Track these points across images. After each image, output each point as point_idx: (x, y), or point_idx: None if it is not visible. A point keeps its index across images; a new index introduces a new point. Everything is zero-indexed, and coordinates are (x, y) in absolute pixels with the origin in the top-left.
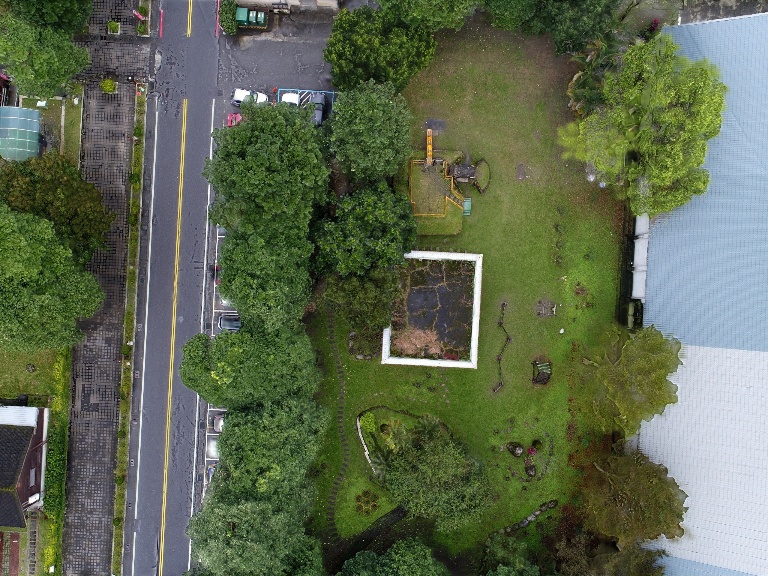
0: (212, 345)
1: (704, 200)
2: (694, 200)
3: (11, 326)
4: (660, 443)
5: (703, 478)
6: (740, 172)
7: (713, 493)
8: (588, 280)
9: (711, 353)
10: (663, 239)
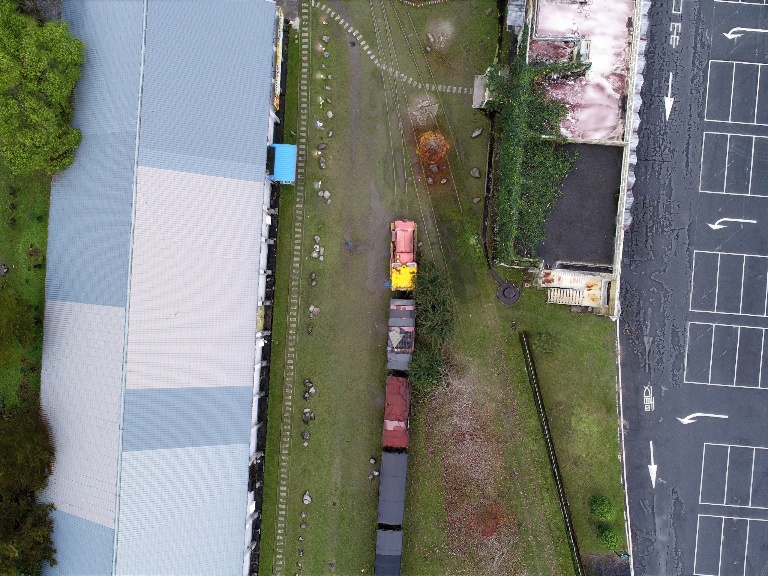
0: None
1: (84, 159)
2: (78, 159)
3: None
4: (53, 399)
5: (77, 432)
6: (105, 131)
7: (82, 447)
8: (41, 242)
9: (85, 309)
10: (59, 198)
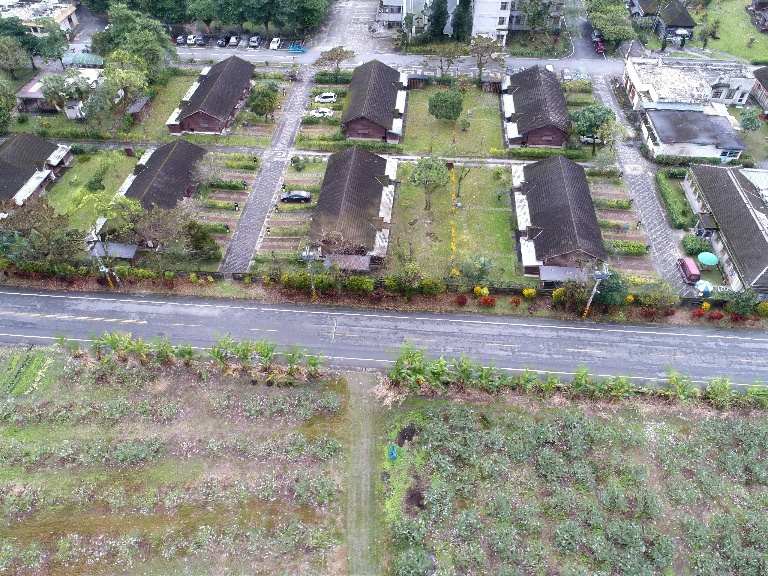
0: (190, 4)
1: None
2: None
3: (158, 21)
4: None
5: None
6: None
7: None
8: None
9: None
10: None
